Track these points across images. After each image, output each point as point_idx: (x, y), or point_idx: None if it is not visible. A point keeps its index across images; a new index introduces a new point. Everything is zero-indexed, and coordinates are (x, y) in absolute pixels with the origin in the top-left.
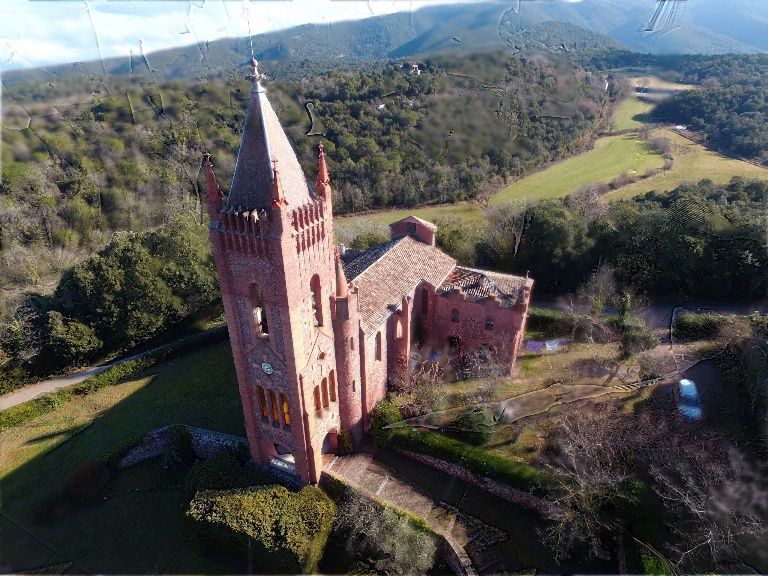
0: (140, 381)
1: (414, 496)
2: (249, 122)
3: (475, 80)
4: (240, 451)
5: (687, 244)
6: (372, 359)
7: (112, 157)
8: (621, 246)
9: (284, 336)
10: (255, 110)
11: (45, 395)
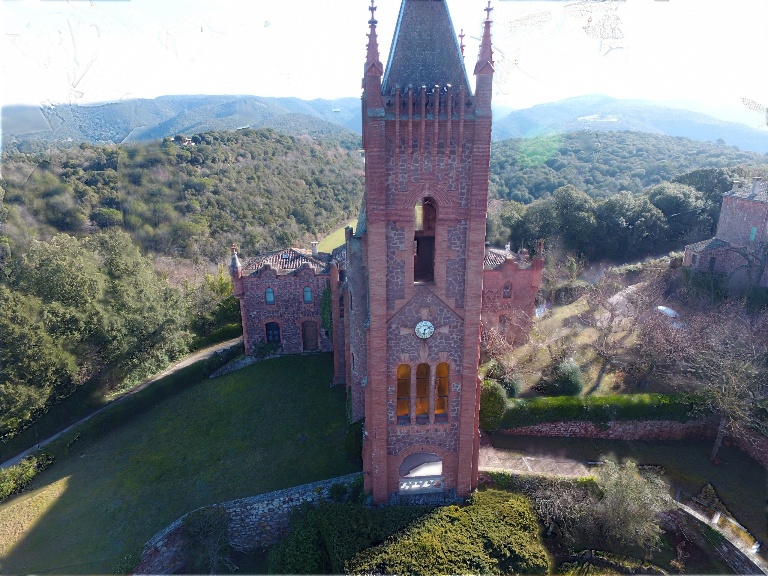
0: (41, 494)
1: (563, 466)
2: None
3: (540, 8)
4: None
5: (583, 218)
6: None
7: None
8: (528, 232)
9: (470, 265)
10: None
11: None
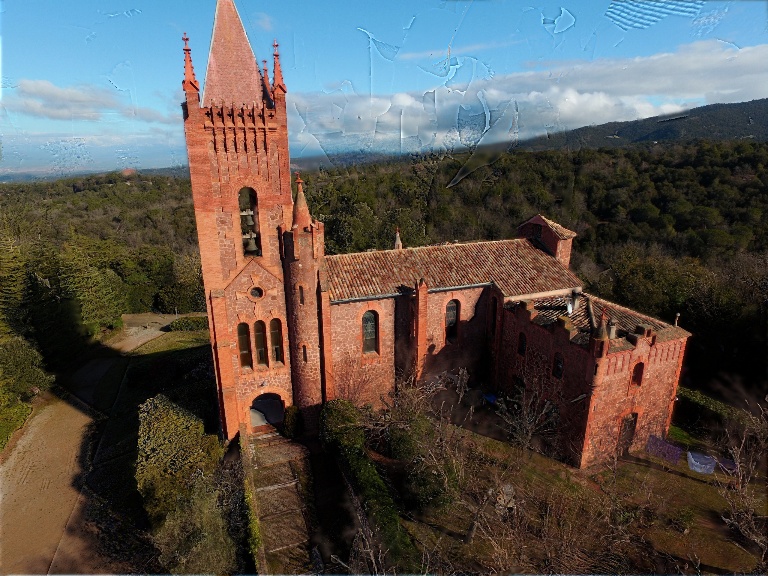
0: None
1: (297, 519)
2: None
3: None
4: None
5: None
6: (356, 341)
7: (375, 172)
8: None
9: None
10: None
11: None
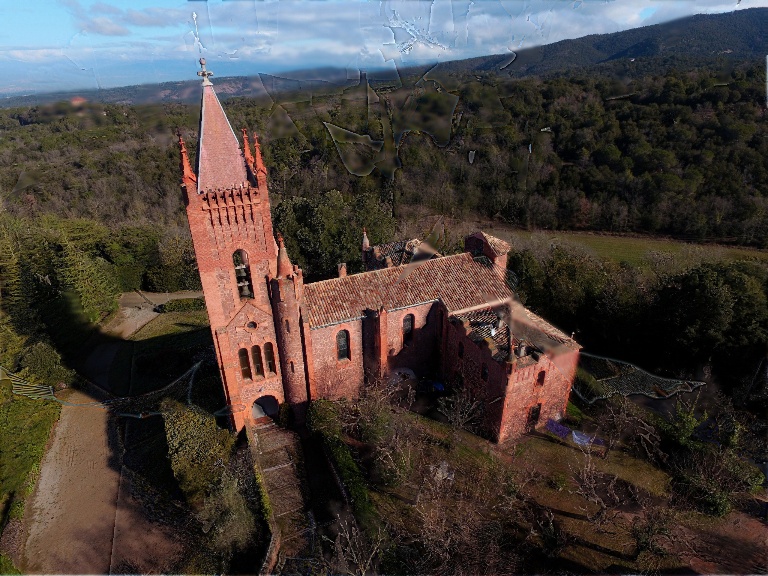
0: None
1: (295, 491)
2: None
3: None
4: None
5: None
6: (332, 353)
7: None
8: None
9: None
10: None
11: (202, 298)
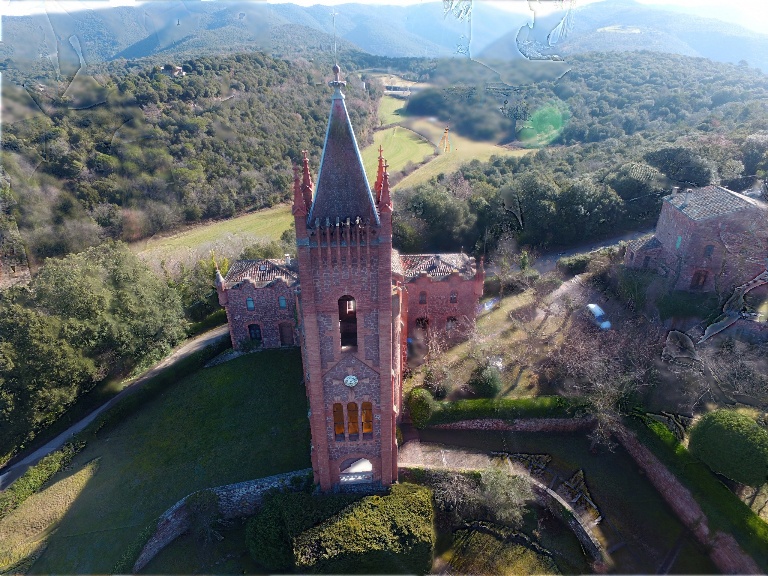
0: (80, 473)
1: (471, 457)
2: (332, 130)
3: (468, 83)
4: (292, 487)
5: (544, 207)
6: None
7: None
8: (494, 217)
9: (381, 340)
10: (339, 117)
11: None
